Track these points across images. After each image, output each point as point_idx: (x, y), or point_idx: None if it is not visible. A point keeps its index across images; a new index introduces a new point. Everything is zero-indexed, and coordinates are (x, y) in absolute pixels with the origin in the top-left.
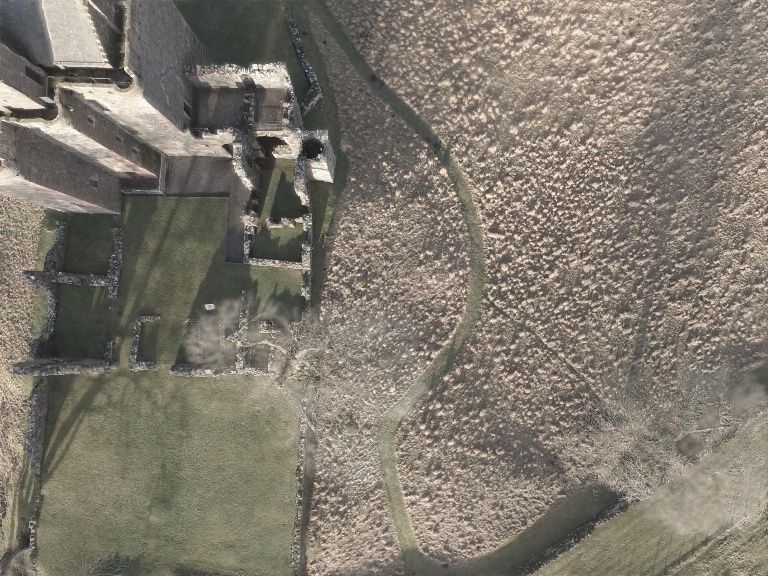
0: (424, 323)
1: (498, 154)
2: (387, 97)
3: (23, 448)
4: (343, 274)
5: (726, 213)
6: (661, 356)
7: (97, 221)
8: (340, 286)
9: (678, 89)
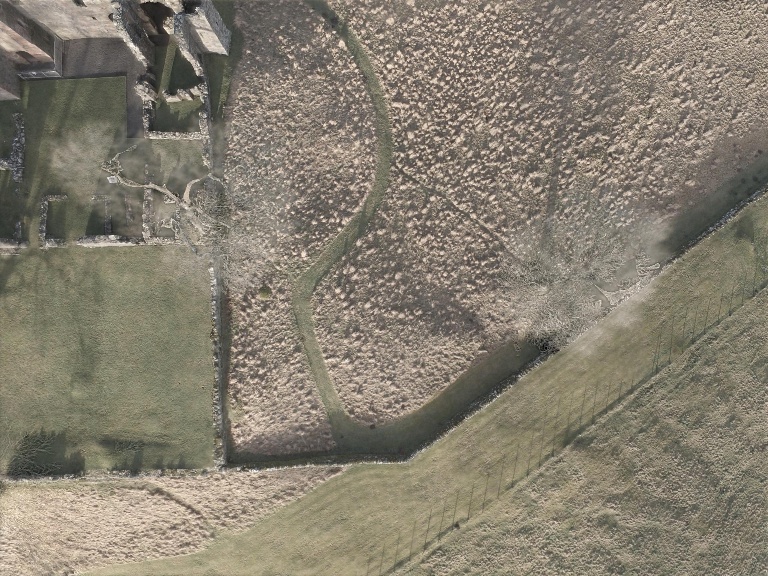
0: (333, 192)
1: (396, 26)
2: None
3: None
4: (245, 143)
5: (629, 70)
6: (574, 212)
7: None
8: (243, 155)
9: None
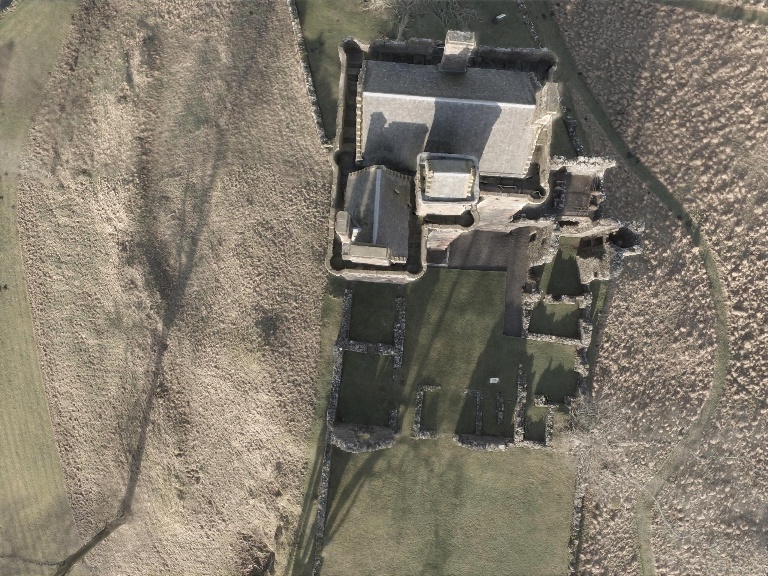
0: (676, 398)
1: (743, 233)
2: (642, 174)
3: (302, 509)
4: (612, 351)
5: None
6: None
7: (381, 290)
8: (609, 362)
9: None
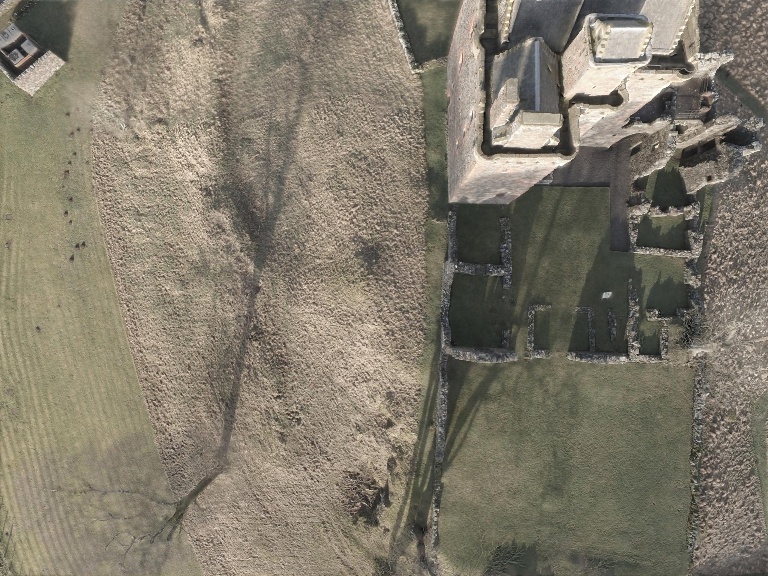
0: None
1: None
2: (733, 87)
3: (417, 437)
4: (720, 262)
5: None
6: None
7: (484, 211)
8: (718, 274)
9: None
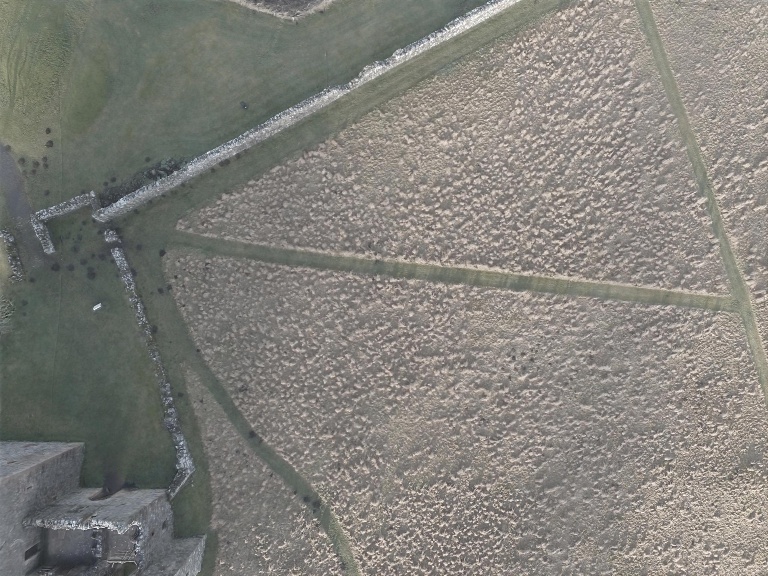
0: None
1: (381, 507)
2: (266, 454)
3: None
4: None
5: (622, 555)
6: None
7: None
8: None
9: (573, 425)
